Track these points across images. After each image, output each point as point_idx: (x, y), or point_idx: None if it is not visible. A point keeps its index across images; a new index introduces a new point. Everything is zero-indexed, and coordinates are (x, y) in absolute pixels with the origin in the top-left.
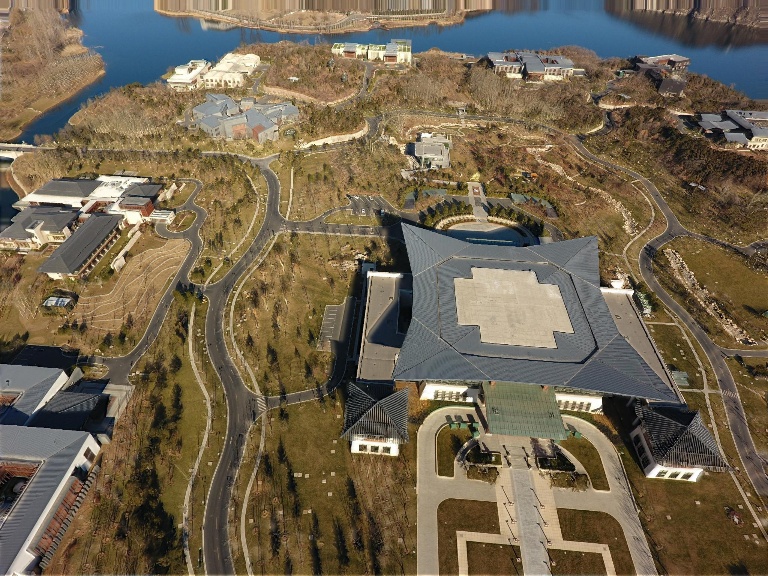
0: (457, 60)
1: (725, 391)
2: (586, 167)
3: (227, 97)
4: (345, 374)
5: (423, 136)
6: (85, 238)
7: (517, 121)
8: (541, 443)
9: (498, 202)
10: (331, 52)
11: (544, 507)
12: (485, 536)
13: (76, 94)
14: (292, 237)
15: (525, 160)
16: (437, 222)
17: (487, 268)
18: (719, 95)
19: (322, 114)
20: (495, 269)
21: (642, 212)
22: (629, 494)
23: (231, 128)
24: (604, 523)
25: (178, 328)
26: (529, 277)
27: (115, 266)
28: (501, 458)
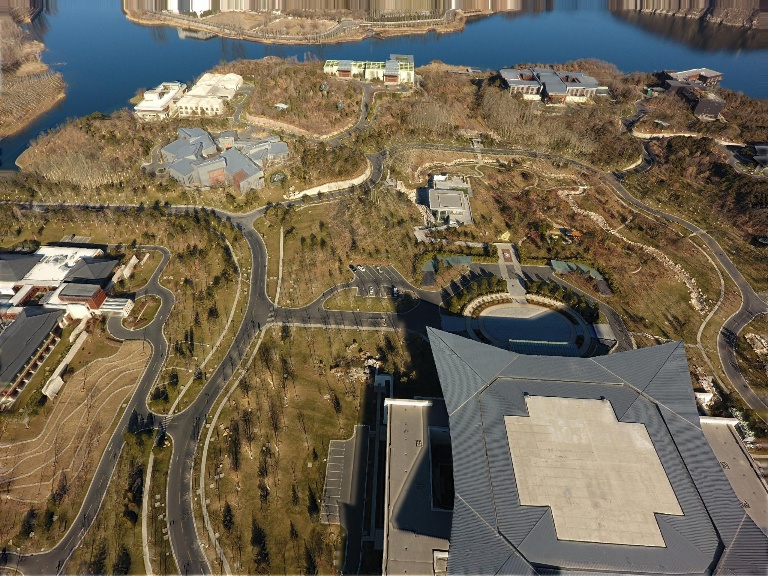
0: (462, 75)
1: None
2: (631, 216)
3: (203, 132)
4: (361, 567)
5: (436, 179)
6: (8, 353)
7: (542, 155)
8: None
9: (536, 272)
10: (323, 72)
11: None
12: None
13: (28, 125)
14: (283, 333)
15: (560, 210)
16: (465, 305)
17: (546, 396)
18: (761, 117)
19: (316, 155)
20: (556, 398)
21: (708, 279)
22: None
23: (207, 175)
24: None
25: (127, 503)
26: (603, 411)
27: (47, 393)
28: None
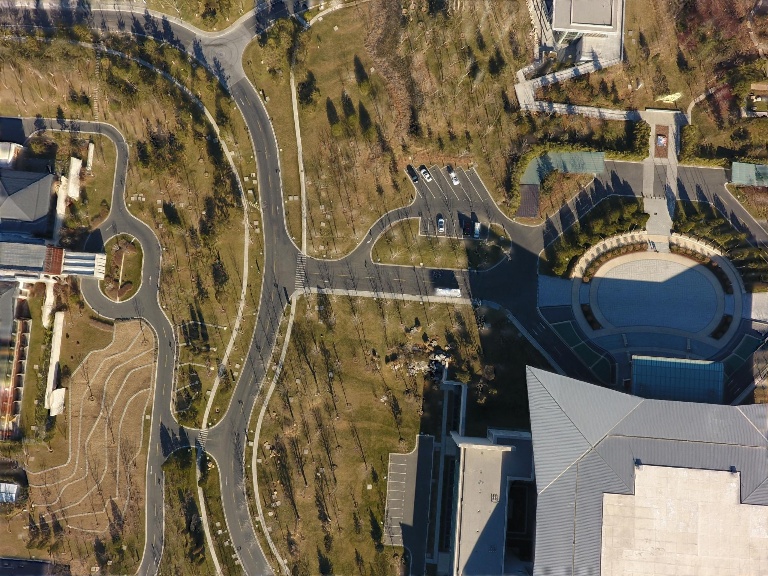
0: None
1: None
2: None
3: None
4: None
5: None
6: None
7: None
8: None
9: (699, 182)
10: None
11: None
12: None
13: None
14: (320, 306)
15: None
16: (576, 259)
17: (662, 467)
18: None
19: None
20: (675, 469)
21: None
22: None
23: None
24: None
25: (190, 547)
26: (728, 488)
27: (53, 415)
28: None
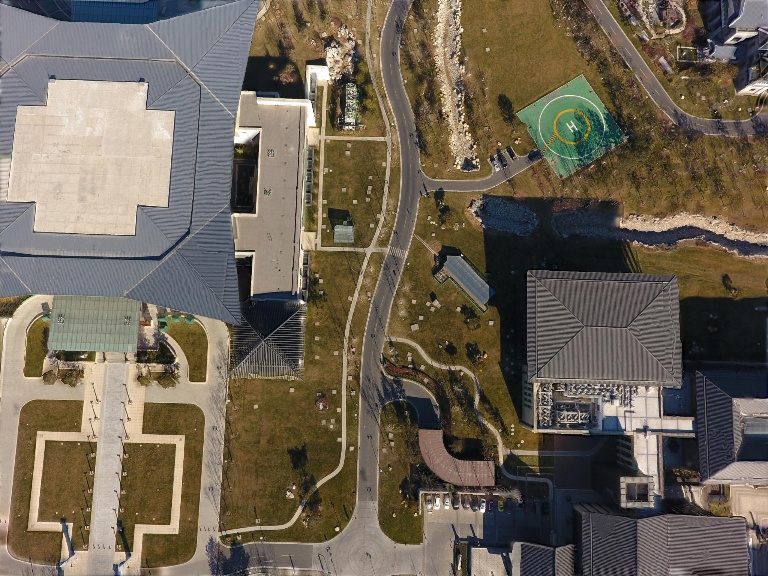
0: None
1: (393, 249)
2: None
3: None
4: None
5: None
6: None
7: None
8: (146, 332)
9: None
10: None
11: (131, 403)
12: (65, 435)
13: None
14: None
15: None
16: None
17: (73, 80)
18: None
19: None
20: (85, 82)
21: None
22: (225, 384)
23: None
24: (188, 415)
25: None
26: (134, 96)
27: None
28: (96, 353)
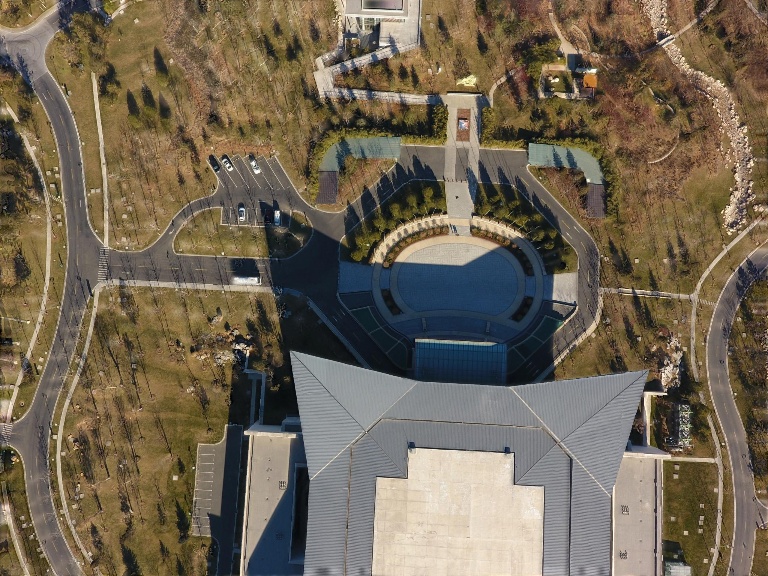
0: None
1: None
2: None
3: None
4: None
5: None
6: None
7: None
8: None
9: (500, 164)
10: None
11: None
12: None
13: None
14: (123, 298)
15: None
16: (376, 244)
17: (435, 450)
18: None
19: None
20: (448, 452)
21: None
22: None
23: None
24: None
25: None
26: (501, 470)
27: None
28: None
